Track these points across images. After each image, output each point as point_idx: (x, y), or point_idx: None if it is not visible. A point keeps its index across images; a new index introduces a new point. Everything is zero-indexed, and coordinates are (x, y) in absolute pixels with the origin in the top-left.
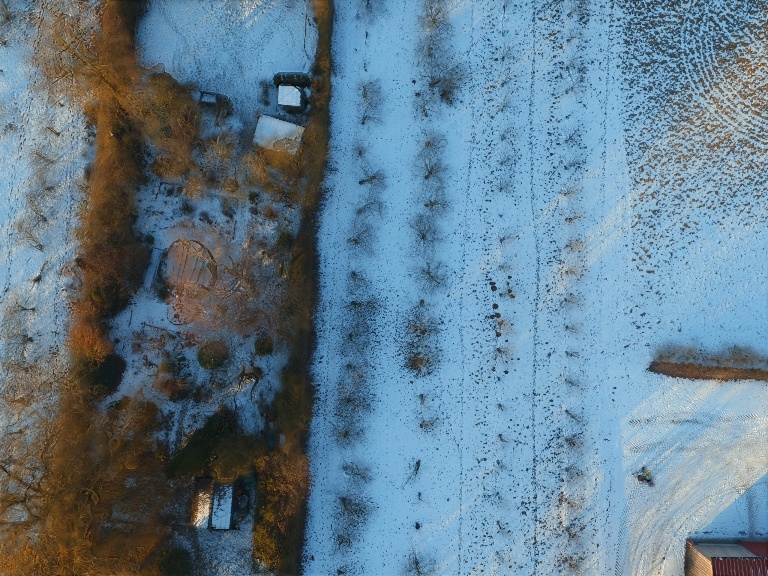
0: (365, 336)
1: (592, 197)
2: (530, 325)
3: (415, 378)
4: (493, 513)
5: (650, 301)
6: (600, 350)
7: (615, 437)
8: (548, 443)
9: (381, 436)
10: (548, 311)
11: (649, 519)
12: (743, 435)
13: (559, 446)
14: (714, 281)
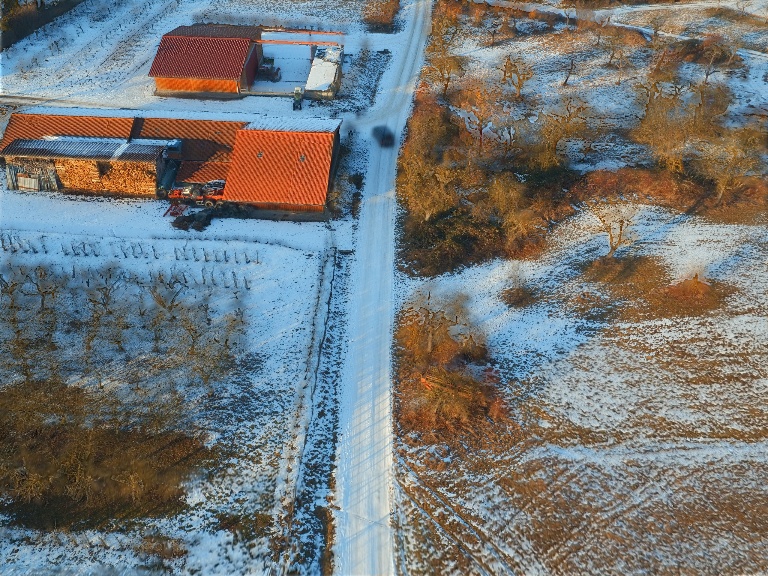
0: None
1: (192, 6)
2: None
3: None
4: None
5: None
6: None
7: None
8: None
9: None
10: None
11: None
12: None
13: None
14: None
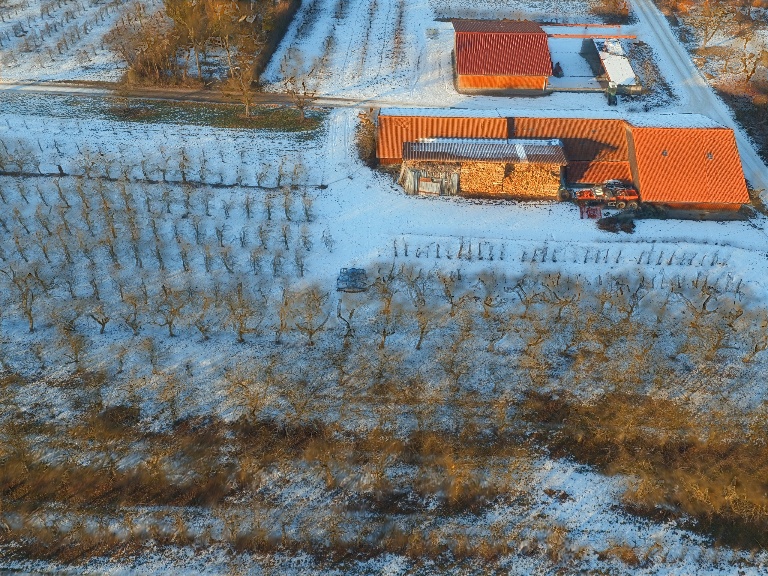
0: (317, 13)
1: None
2: None
3: (336, 19)
4: None
5: None
6: None
7: None
8: (391, 30)
9: None
10: (393, 13)
11: None
12: None
13: None
14: None
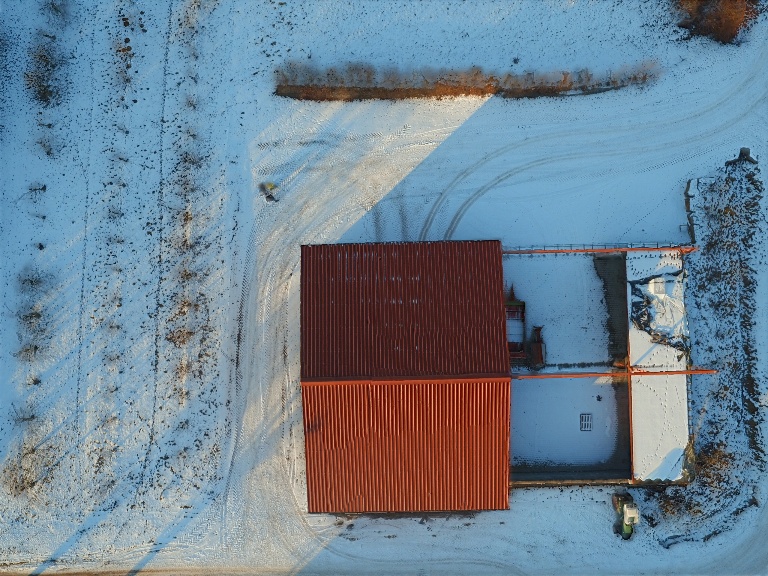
0: None
1: None
2: (161, 57)
3: (44, 109)
4: (118, 233)
5: (281, 31)
6: (229, 78)
7: (243, 160)
8: (175, 167)
9: (8, 164)
10: (179, 43)
11: (277, 238)
12: (369, 153)
13: (186, 169)
14: (347, 11)
